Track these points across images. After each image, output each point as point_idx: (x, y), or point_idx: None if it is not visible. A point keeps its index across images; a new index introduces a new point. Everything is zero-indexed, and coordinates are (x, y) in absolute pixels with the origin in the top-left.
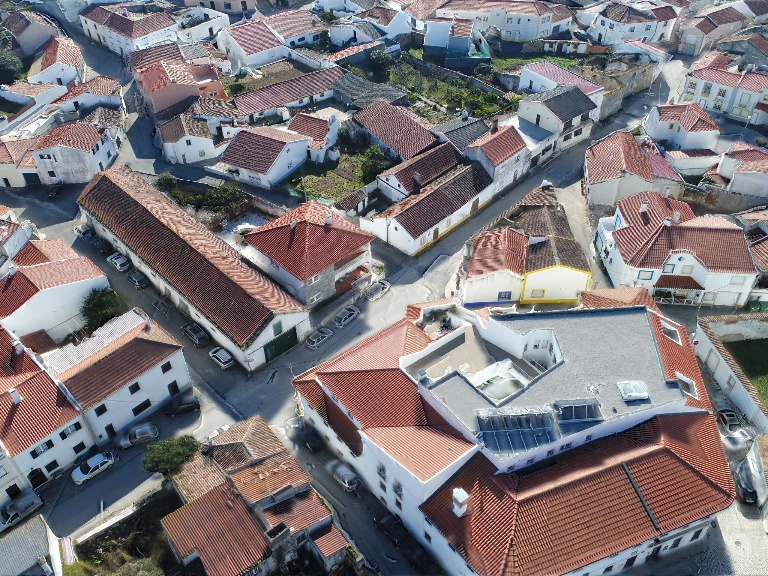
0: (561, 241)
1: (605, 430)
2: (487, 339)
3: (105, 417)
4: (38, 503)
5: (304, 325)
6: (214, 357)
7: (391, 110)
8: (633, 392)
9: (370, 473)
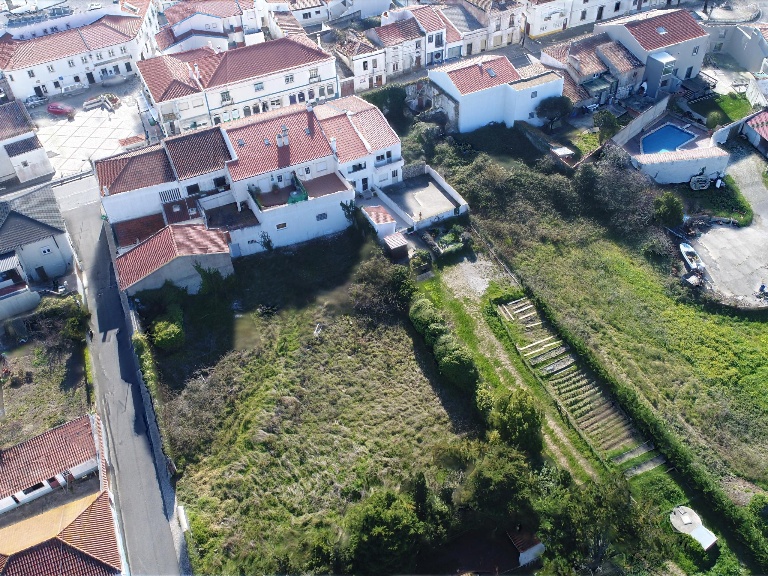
0: None
1: (77, 22)
2: None
3: None
4: None
5: None
6: None
7: None
8: None
9: None
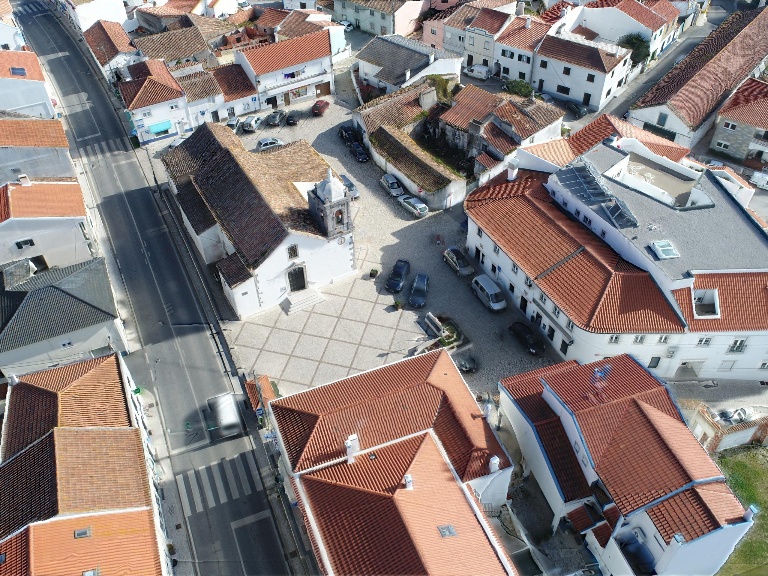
0: None
1: None
2: None
3: (544, 72)
4: (483, 76)
5: (684, 140)
6: None
7: None
8: (661, 247)
9: None
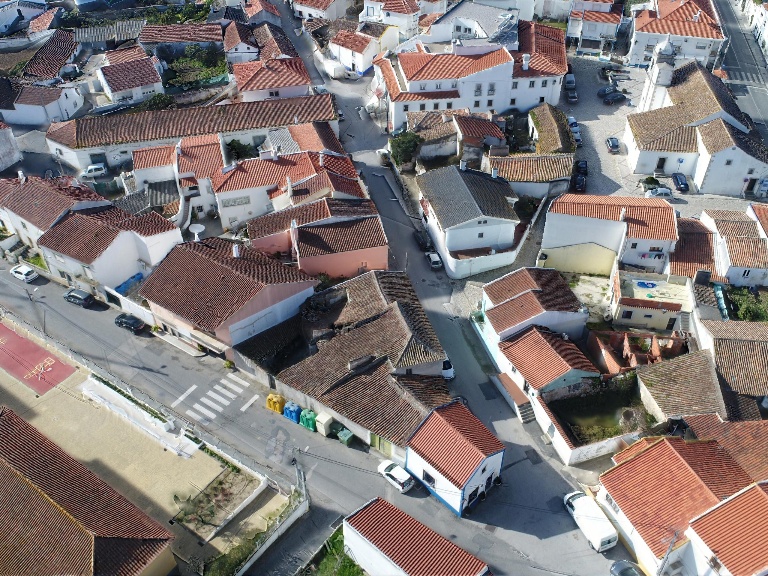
0: None
1: None
2: (433, 42)
3: None
4: None
5: None
6: None
7: (161, 27)
8: (508, 15)
9: (467, 104)
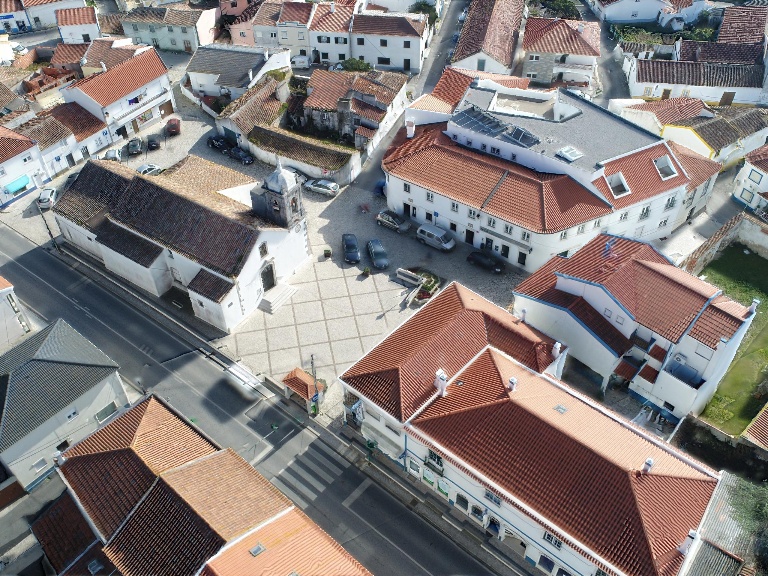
0: (725, 124)
1: (527, 160)
2: None
3: (362, 49)
4: (306, 65)
5: None
6: (444, 67)
7: (761, 13)
8: None
9: None
